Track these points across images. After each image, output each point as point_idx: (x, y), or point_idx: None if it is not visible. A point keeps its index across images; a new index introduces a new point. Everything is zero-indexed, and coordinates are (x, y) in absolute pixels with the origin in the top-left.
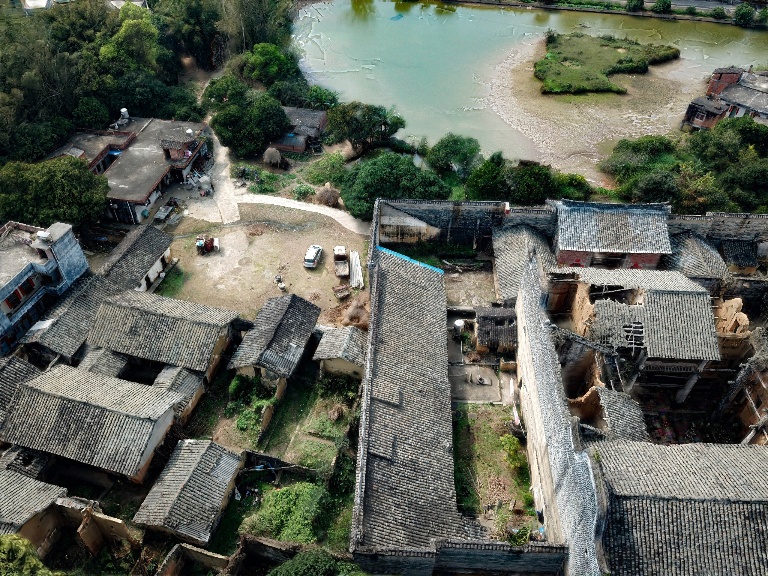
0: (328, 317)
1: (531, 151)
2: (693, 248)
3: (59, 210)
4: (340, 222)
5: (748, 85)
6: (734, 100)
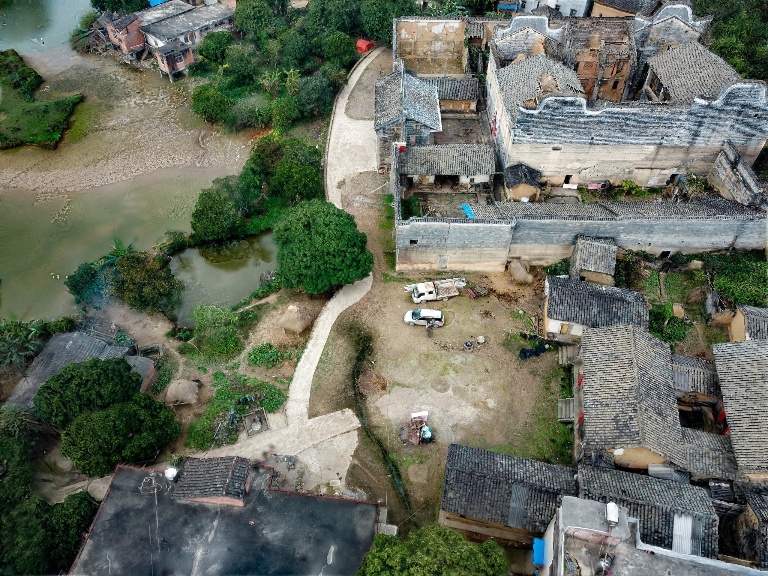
0: (511, 303)
1: (186, 171)
2: (422, 80)
3: (497, 568)
4: (350, 304)
5: (144, 24)
6: (174, 34)
